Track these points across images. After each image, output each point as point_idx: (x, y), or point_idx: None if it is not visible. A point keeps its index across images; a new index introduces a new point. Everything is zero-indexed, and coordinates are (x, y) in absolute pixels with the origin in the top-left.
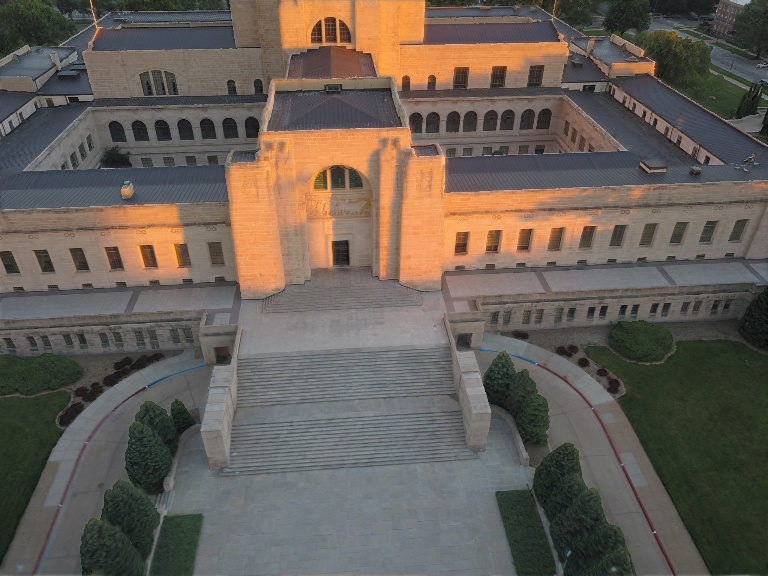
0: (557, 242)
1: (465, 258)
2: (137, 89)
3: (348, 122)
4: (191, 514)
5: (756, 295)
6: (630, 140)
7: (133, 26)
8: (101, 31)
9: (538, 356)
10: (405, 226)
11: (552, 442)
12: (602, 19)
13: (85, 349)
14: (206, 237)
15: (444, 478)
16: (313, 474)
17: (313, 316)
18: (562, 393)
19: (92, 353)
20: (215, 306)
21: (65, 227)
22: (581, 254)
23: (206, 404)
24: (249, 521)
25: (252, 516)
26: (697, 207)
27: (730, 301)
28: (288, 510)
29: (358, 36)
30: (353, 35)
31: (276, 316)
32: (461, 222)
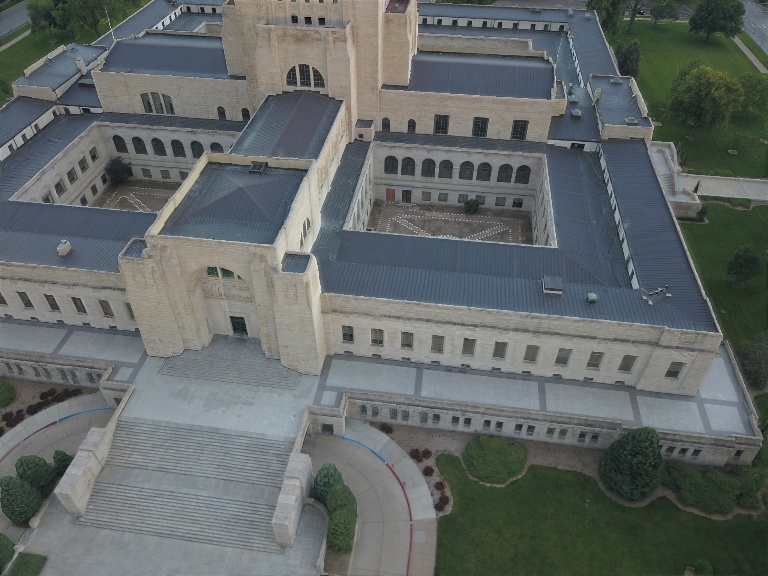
0: (440, 346)
1: (352, 346)
2: (139, 107)
3: (242, 219)
4: (40, 555)
5: (621, 435)
6: (573, 231)
7: (156, 32)
8: (117, 44)
9: (391, 455)
10: (279, 323)
11: (357, 550)
12: (689, 15)
13: (23, 375)
14: (122, 298)
15: (245, 567)
16: (145, 538)
17: (197, 385)
18: (393, 500)
19: (29, 379)
20: (124, 358)
21: (10, 276)
22: (464, 359)
23: (69, 465)
24: (79, 571)
25: (83, 567)
26: (579, 339)
27: (598, 434)
28: (111, 568)
29: (330, 84)
30: (326, 82)
31: (168, 379)
32: (344, 318)
